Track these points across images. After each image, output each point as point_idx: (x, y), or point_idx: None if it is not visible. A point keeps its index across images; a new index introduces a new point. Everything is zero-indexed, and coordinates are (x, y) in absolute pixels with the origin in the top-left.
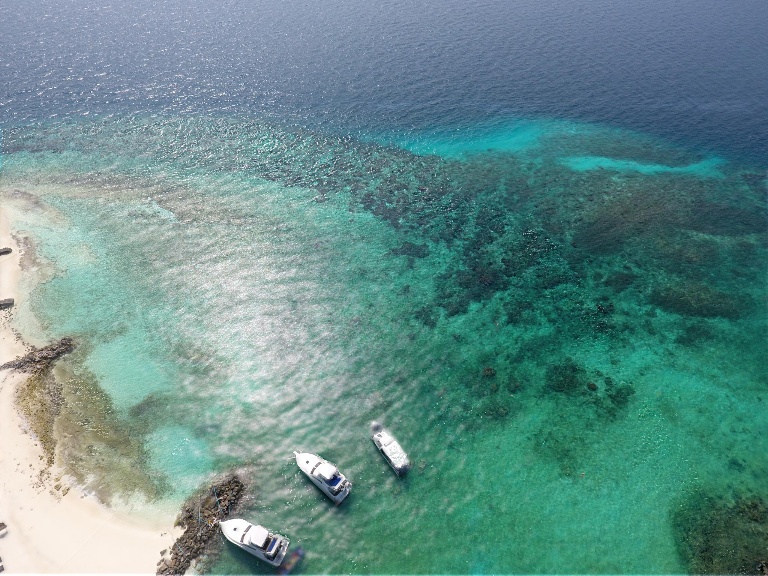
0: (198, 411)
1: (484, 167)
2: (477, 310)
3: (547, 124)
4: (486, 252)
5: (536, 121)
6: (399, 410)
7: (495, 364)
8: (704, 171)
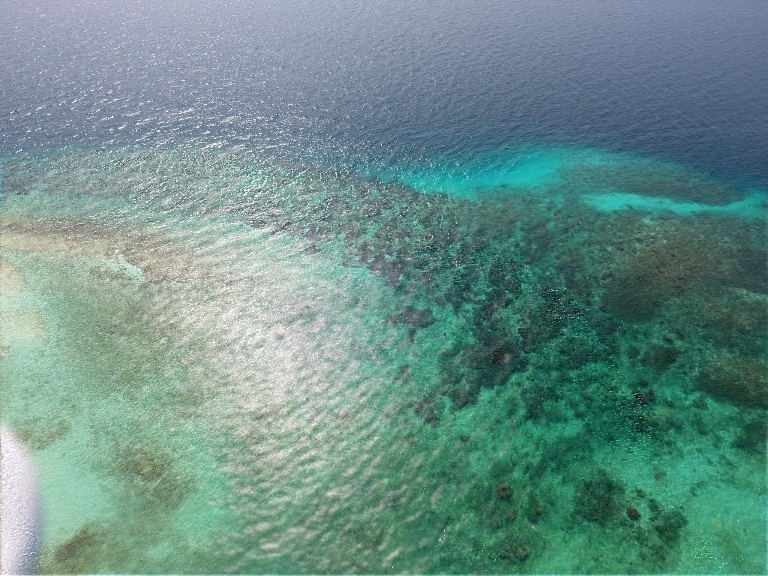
0: (141, 552)
1: (497, 207)
2: (489, 400)
3: (567, 153)
4: (500, 319)
5: (555, 150)
6: (391, 550)
7: (511, 479)
8: (749, 210)
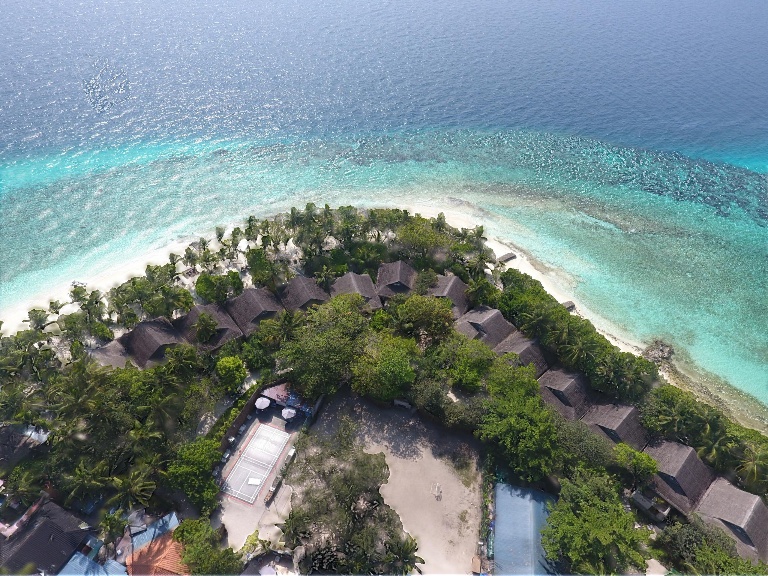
0: None
1: None
2: None
3: None
4: None
5: None
6: None
7: None
8: None
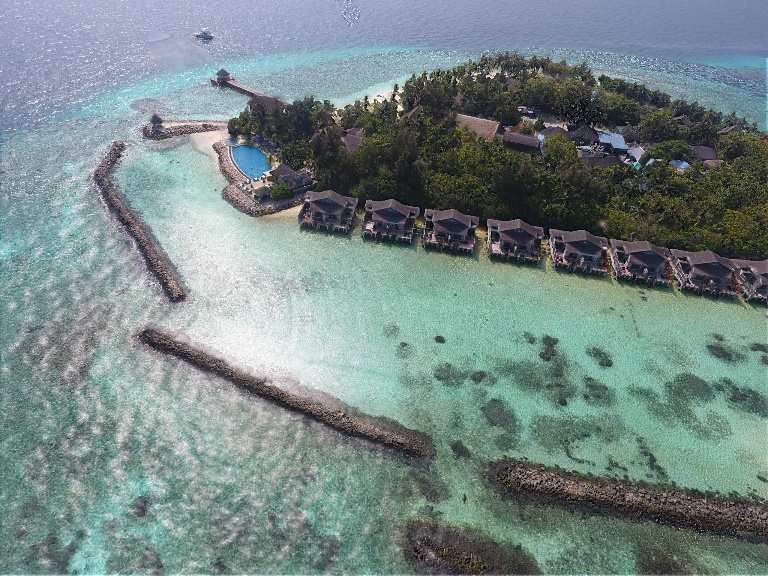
0: None
1: (753, 72)
2: None
3: (761, 58)
4: None
5: (754, 57)
6: None
7: None
8: None
